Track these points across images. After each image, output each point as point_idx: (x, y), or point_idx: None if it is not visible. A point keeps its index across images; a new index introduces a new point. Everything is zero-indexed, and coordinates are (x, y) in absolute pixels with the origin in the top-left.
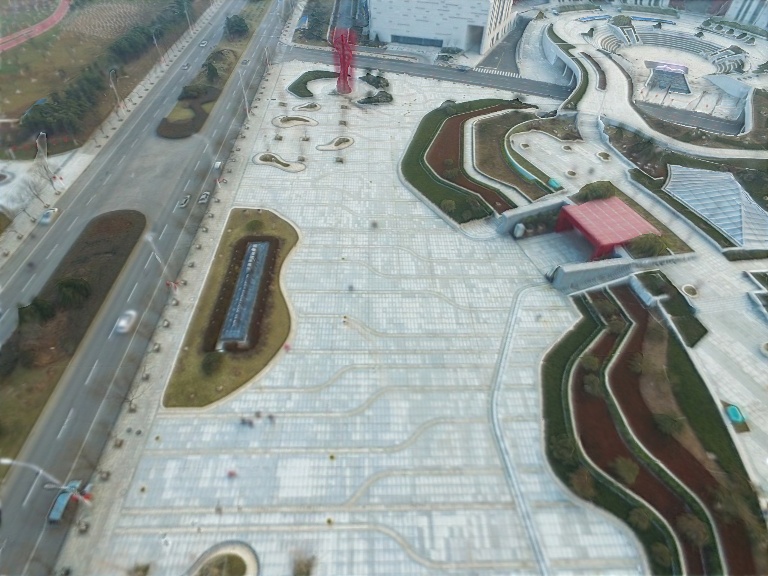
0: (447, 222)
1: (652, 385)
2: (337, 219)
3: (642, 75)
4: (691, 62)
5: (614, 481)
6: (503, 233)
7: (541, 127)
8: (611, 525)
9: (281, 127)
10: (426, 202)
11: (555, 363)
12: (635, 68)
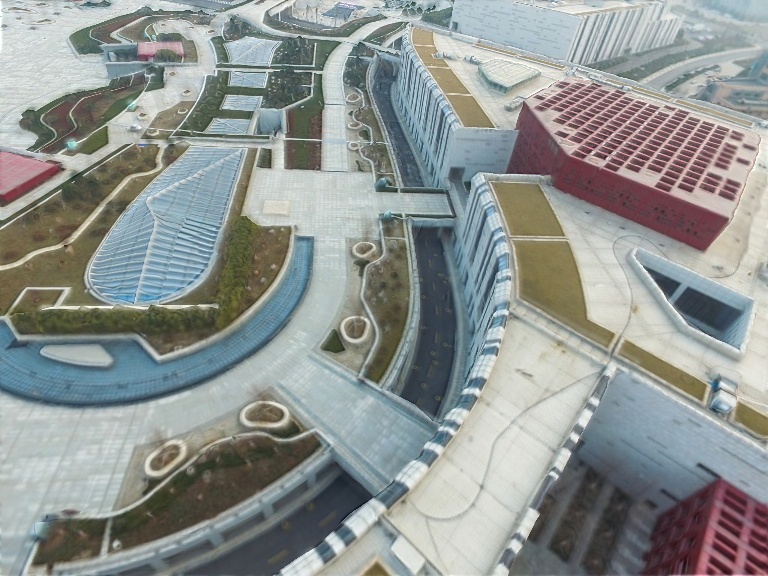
0: (76, 55)
1: (106, 101)
2: (1, 50)
3: (325, 9)
4: (373, 5)
5: (46, 125)
6: (105, 60)
7: (190, 19)
8: (32, 138)
9: (6, 12)
10: (72, 47)
11: (66, 97)
12: (324, 5)
